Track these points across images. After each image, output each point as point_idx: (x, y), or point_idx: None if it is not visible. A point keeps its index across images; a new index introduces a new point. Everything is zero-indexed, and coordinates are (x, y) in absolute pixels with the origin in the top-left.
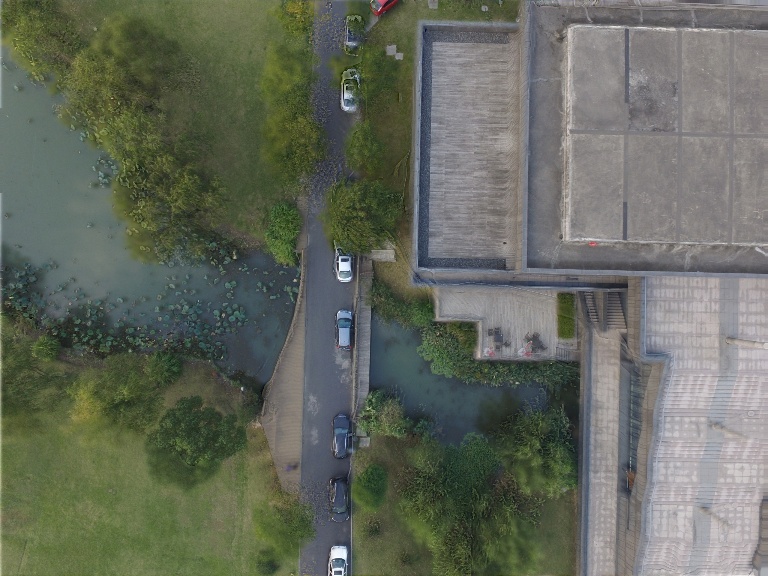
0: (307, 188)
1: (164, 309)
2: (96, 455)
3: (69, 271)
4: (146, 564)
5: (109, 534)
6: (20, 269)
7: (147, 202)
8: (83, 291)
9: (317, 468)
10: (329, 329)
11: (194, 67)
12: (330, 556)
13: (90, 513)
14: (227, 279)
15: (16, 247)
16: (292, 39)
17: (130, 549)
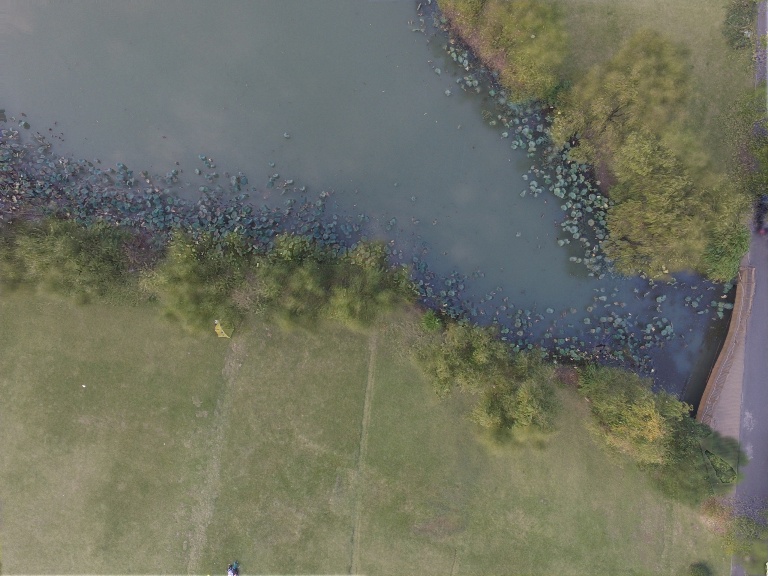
0: (750, 205)
1: (596, 321)
2: (526, 465)
3: (497, 280)
4: (578, 574)
5: (541, 544)
6: (450, 276)
7: (583, 213)
8: (511, 300)
9: (751, 483)
10: (767, 346)
11: (633, 79)
12: (767, 570)
13: (521, 523)
14: (659, 293)
15: (443, 254)
16: (735, 55)
17: (562, 559)
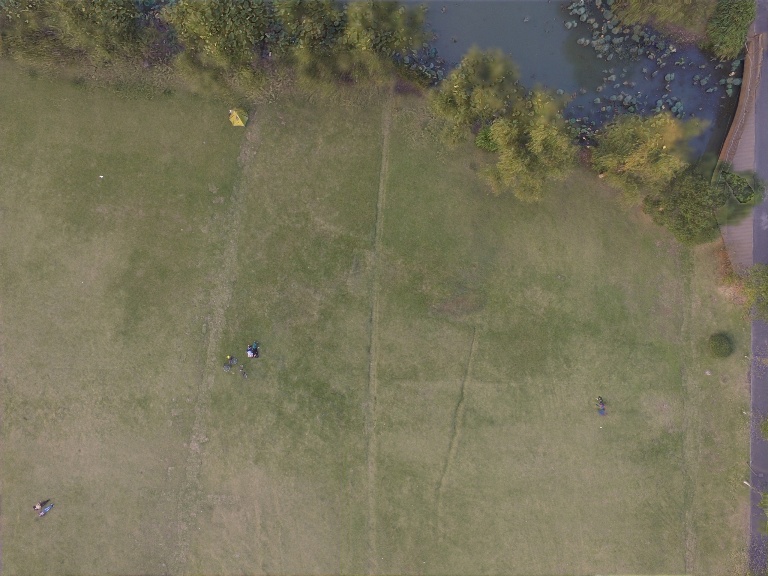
0: None
1: (606, 100)
2: (542, 243)
3: (506, 64)
4: (598, 348)
5: (560, 319)
6: (460, 61)
7: None
8: (521, 84)
9: (767, 253)
10: None
11: None
12: None
13: (539, 299)
14: (668, 71)
15: (453, 41)
16: None
17: (581, 334)
